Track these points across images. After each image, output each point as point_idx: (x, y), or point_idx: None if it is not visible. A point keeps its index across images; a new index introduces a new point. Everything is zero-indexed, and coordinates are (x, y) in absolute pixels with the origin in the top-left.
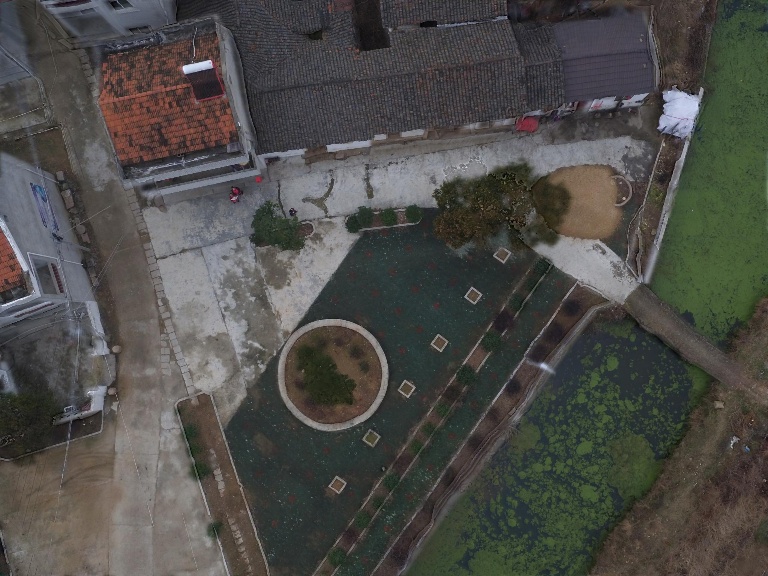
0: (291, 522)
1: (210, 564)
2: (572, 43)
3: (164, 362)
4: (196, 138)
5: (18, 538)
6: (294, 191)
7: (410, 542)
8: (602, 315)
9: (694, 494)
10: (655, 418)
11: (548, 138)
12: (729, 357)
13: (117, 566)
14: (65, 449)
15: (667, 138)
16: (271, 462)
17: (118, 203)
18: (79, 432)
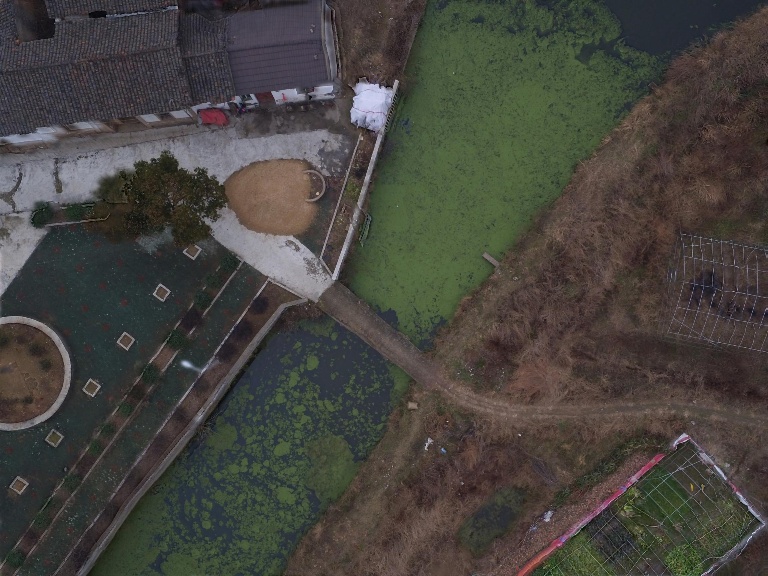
0: None
1: None
2: (242, 34)
3: None
4: None
5: None
6: None
7: (92, 544)
8: (295, 313)
9: (386, 497)
10: (355, 419)
11: (242, 132)
12: (426, 357)
13: None
14: None
15: (363, 132)
16: None
17: None
18: None
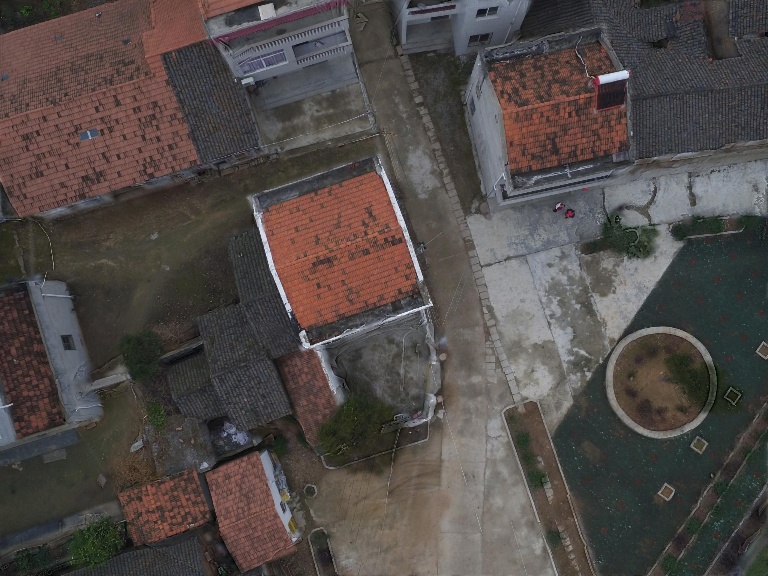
0: (620, 529)
1: (540, 571)
2: None
3: (490, 370)
4: (587, 147)
5: (346, 546)
6: (618, 199)
7: (738, 548)
8: None
9: None
10: None
11: None
12: None
13: (446, 574)
14: (391, 457)
15: None
16: (599, 469)
17: (443, 210)
18: (405, 440)
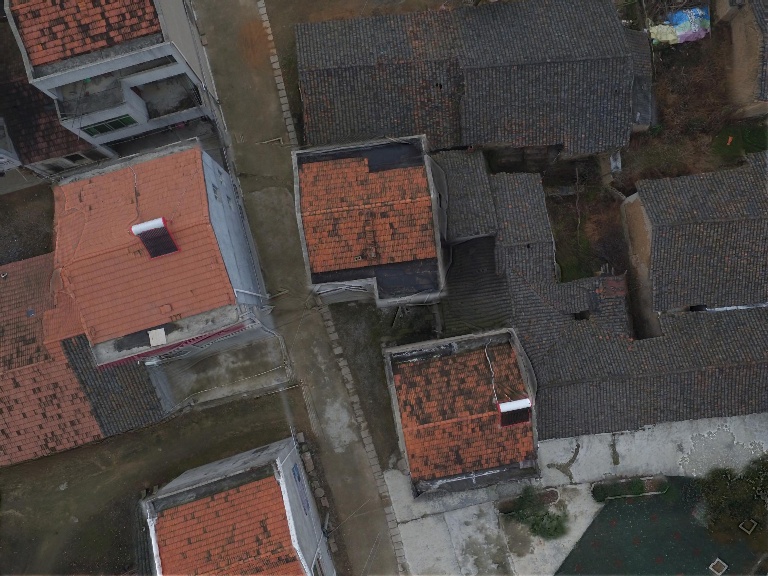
0: None
1: None
2: None
3: None
4: (492, 457)
5: None
6: (539, 456)
7: None
8: None
9: None
10: None
11: None
12: None
13: None
14: None
15: None
16: None
17: (360, 465)
18: None
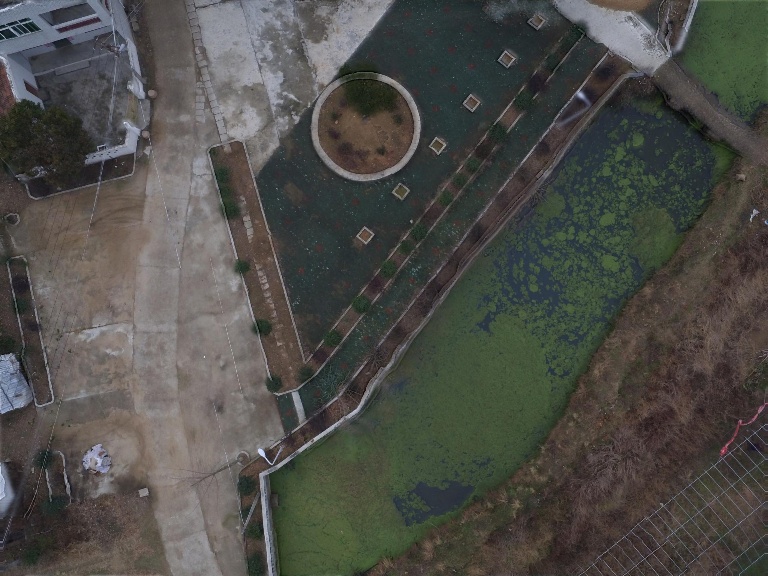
0: (318, 270)
1: (235, 308)
2: None
3: (198, 109)
4: None
5: (44, 275)
6: None
7: (434, 295)
8: (631, 86)
9: (713, 263)
10: (677, 194)
11: None
12: (752, 134)
13: (143, 306)
14: (96, 190)
15: None
16: (300, 211)
17: None
18: (110, 174)
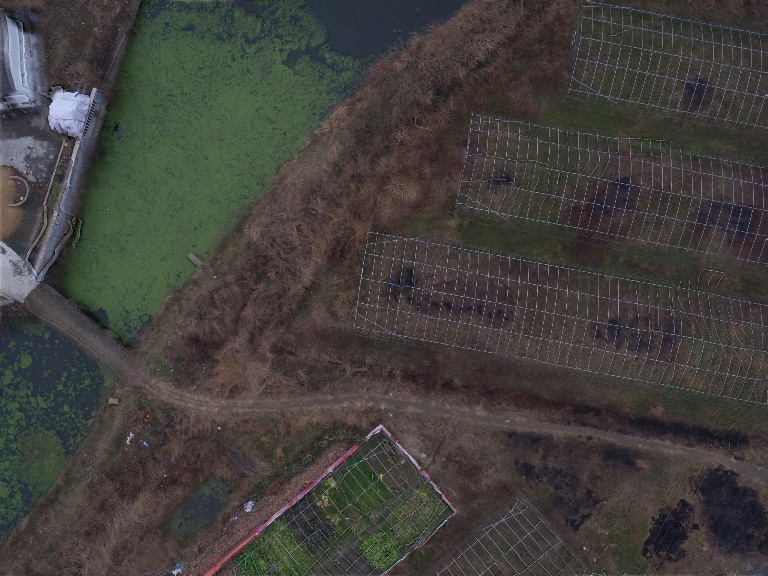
0: None
1: None
2: None
3: None
4: None
5: None
6: None
7: None
8: (3, 314)
9: (88, 489)
10: (66, 415)
11: None
12: (129, 354)
13: None
14: None
15: (66, 138)
16: None
17: None
18: None
